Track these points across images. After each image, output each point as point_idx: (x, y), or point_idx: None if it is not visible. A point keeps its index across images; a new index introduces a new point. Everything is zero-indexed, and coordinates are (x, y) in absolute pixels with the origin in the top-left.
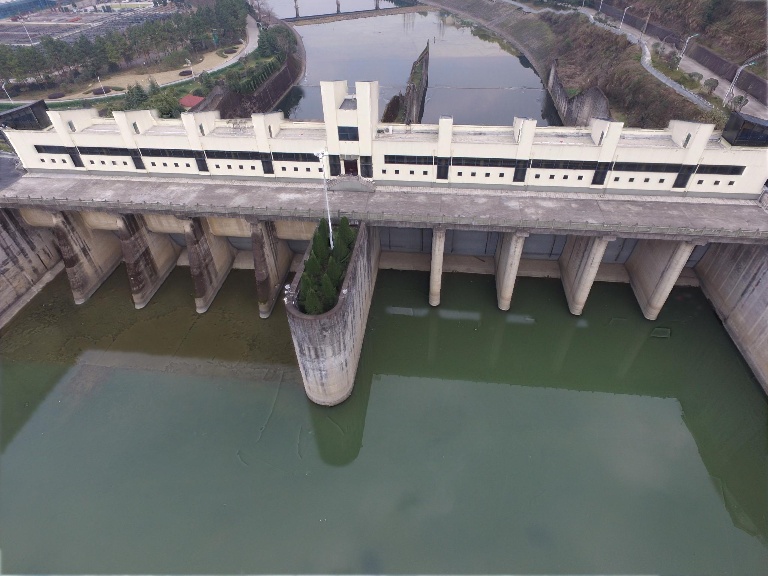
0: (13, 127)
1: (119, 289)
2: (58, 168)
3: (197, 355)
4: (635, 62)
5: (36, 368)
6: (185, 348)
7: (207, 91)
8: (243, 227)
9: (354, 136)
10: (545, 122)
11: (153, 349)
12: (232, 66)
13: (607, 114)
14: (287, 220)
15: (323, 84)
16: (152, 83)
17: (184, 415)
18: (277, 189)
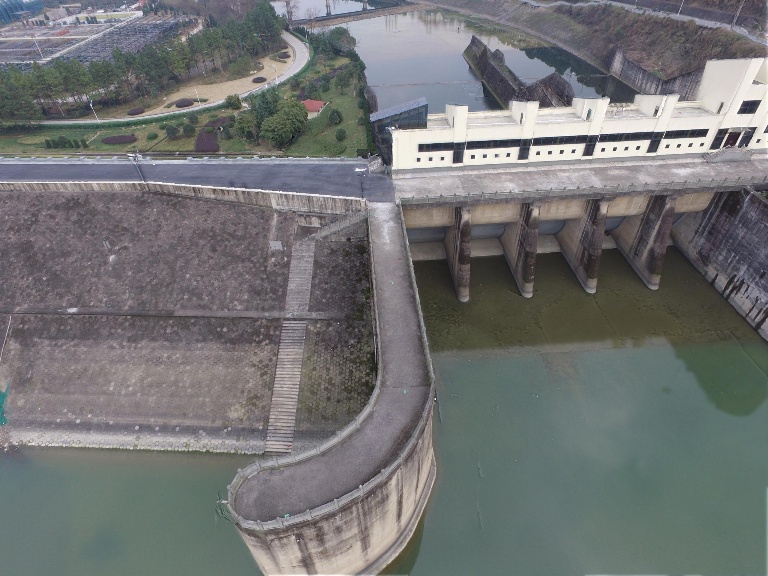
0: None
1: (486, 283)
2: (431, 166)
3: (636, 329)
4: (749, 42)
5: (495, 364)
6: (617, 325)
7: (316, 95)
8: (631, 205)
9: (751, 109)
10: None
11: (589, 330)
12: (304, 70)
13: None
14: (712, 191)
15: (754, 61)
16: (274, 89)
17: (688, 380)
18: (661, 166)
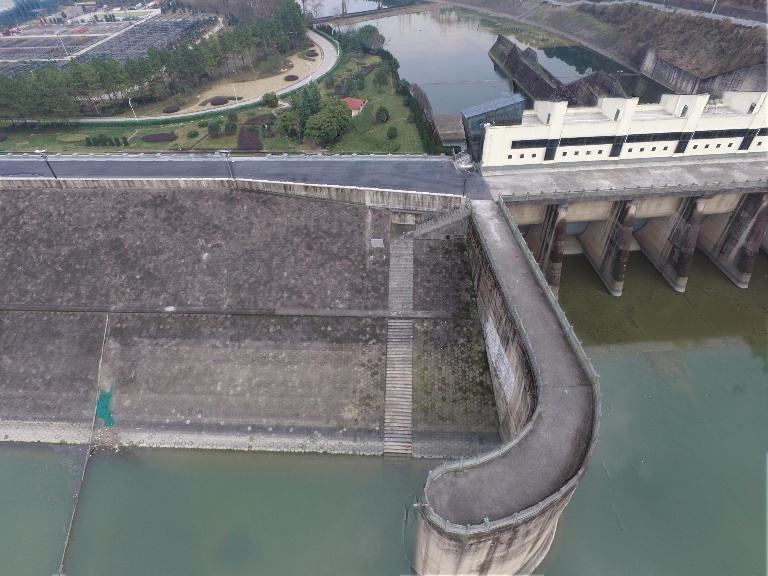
0: None
1: (571, 282)
2: (521, 164)
3: (734, 328)
4: None
5: (598, 363)
6: (715, 324)
7: (354, 93)
8: (722, 203)
9: None
10: None
11: (686, 329)
12: (335, 68)
13: None
14: None
15: None
16: (315, 87)
17: None
18: (753, 164)
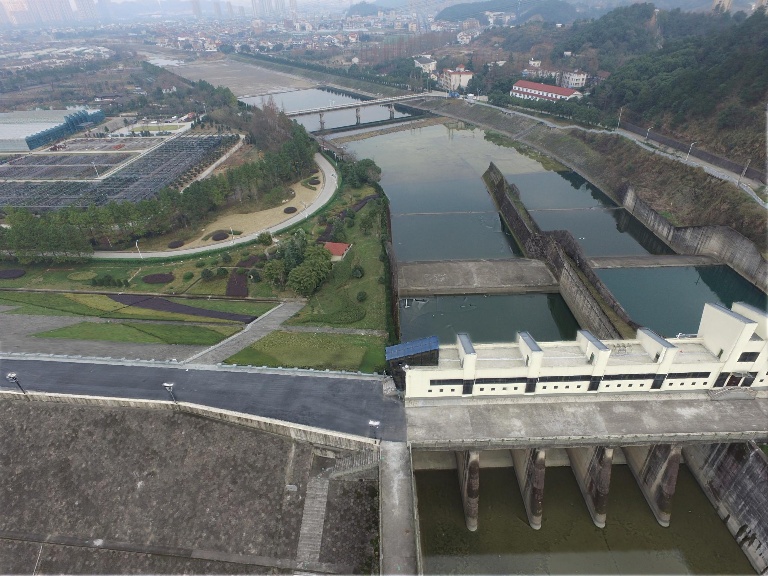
0: (409, 364)
1: (495, 505)
2: (442, 396)
3: None
4: (756, 205)
5: None
6: (627, 575)
7: (341, 236)
8: None
9: (750, 358)
10: (629, 237)
11: None
12: (332, 200)
13: (760, 256)
14: None
15: (748, 326)
16: (302, 236)
17: None
18: (666, 403)
